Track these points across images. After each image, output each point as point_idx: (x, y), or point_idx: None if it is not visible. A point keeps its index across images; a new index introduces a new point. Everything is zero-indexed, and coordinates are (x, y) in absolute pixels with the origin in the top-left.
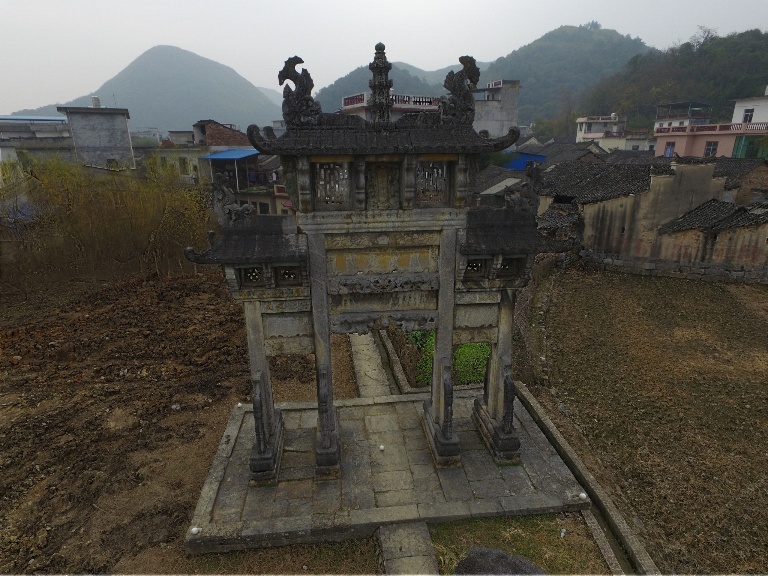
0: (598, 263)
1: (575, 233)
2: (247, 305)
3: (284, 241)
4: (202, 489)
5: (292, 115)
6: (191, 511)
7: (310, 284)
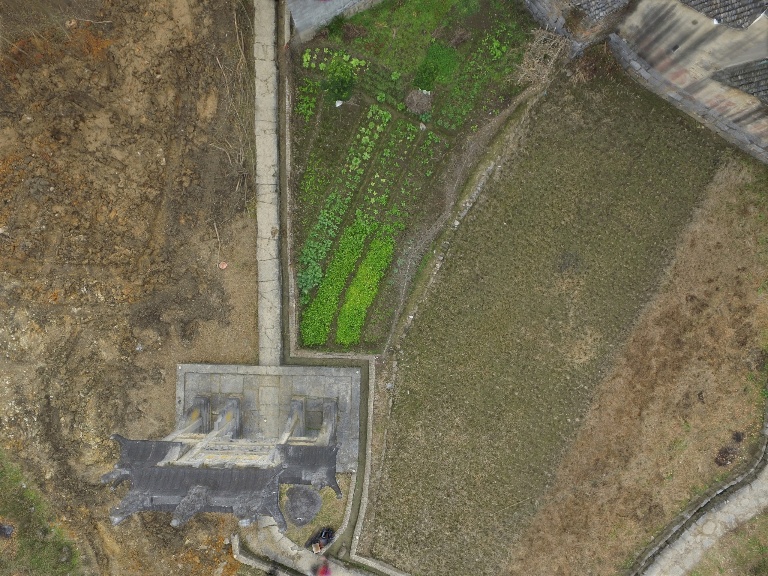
0: (624, 59)
1: (615, 16)
2: None
3: None
4: None
5: None
6: None
7: None
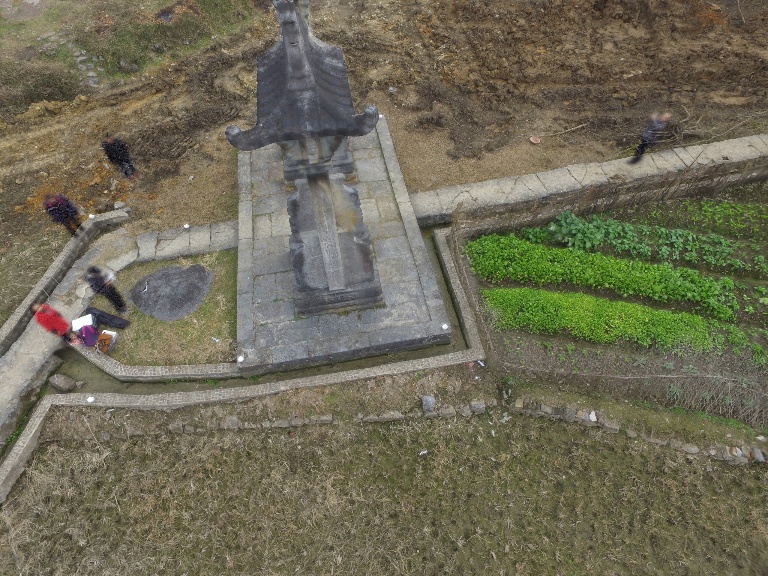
0: None
1: None
2: None
3: None
4: None
5: None
6: None
7: None
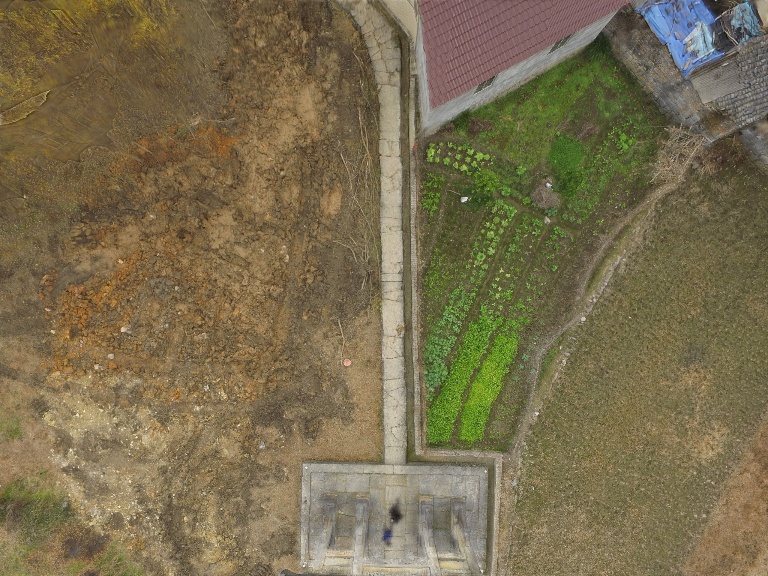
0: (753, 153)
1: None
2: None
3: None
4: (301, 538)
5: None
6: (297, 537)
7: None
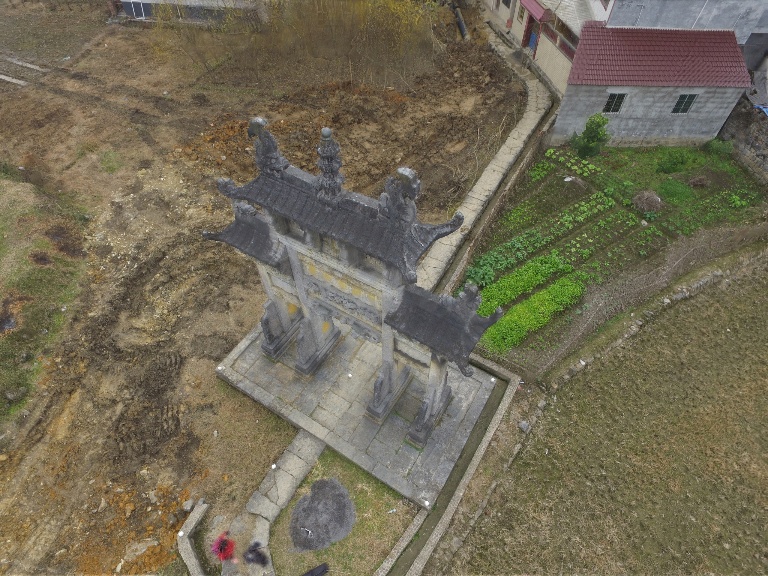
0: None
1: None
2: (258, 264)
3: (270, 243)
4: (241, 341)
5: (262, 165)
6: None
7: (292, 273)
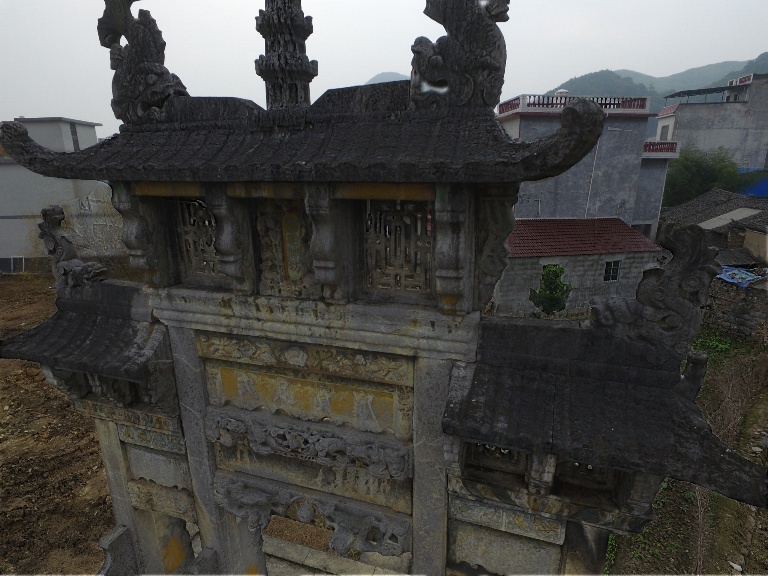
0: None
1: None
2: (98, 423)
3: (130, 333)
4: None
5: (125, 104)
6: None
7: (180, 412)
